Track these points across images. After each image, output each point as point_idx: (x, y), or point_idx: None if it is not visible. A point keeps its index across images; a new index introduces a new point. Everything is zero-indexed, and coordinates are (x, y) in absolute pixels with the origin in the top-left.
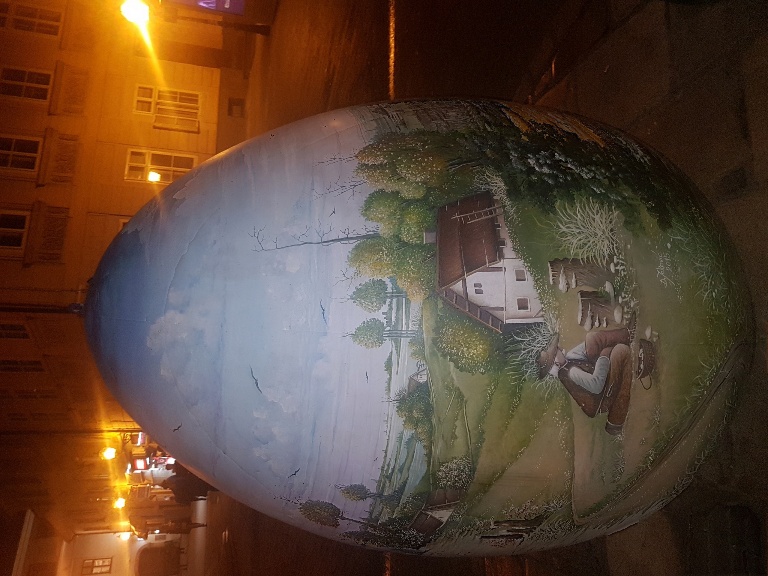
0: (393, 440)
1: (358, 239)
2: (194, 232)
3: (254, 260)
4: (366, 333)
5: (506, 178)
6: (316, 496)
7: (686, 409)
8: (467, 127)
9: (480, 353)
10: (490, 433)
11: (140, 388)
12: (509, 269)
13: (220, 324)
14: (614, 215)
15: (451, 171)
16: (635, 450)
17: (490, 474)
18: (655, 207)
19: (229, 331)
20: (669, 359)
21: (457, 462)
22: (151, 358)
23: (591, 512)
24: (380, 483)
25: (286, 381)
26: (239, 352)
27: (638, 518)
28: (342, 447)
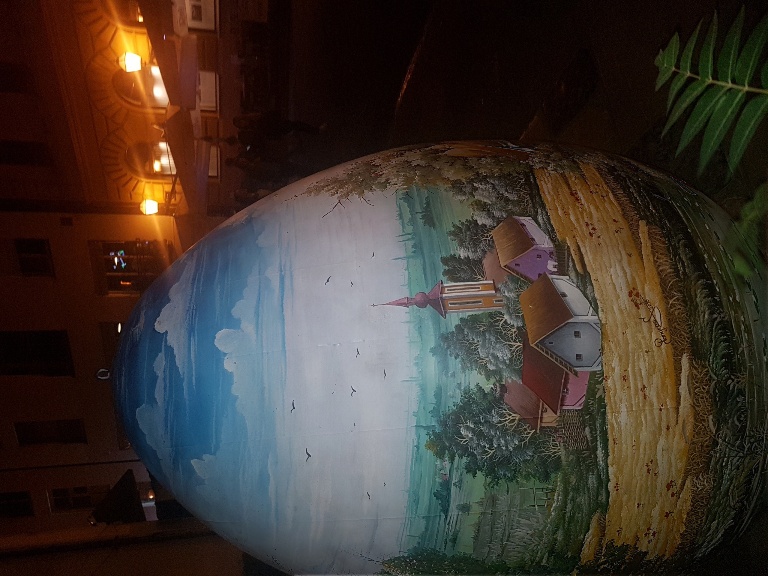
0: None
1: None
2: None
3: None
4: None
5: None
6: None
7: None
8: (521, 559)
9: None
10: None
11: None
12: None
13: None
14: None
15: None
16: None
17: None
18: None
19: None
20: None
21: None
22: None
23: None
24: None
25: None
26: None
27: None
28: None
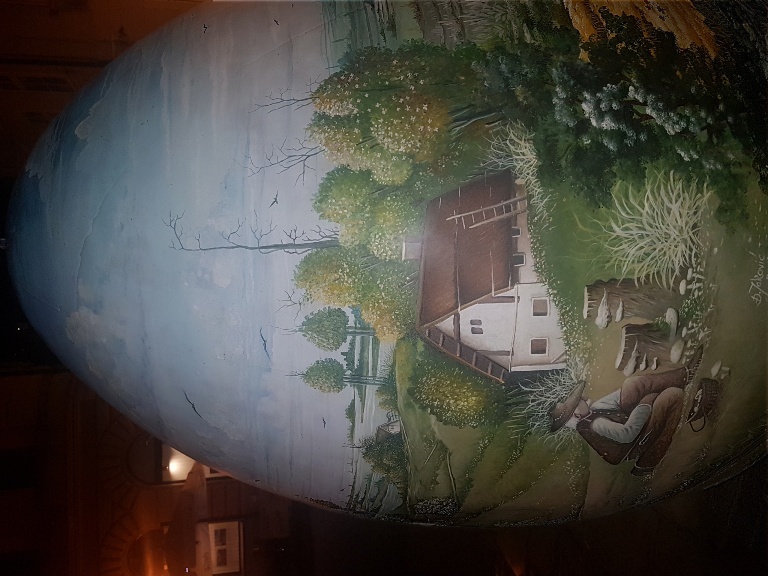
0: (360, 479)
1: (309, 247)
2: (97, 204)
3: (172, 262)
4: (321, 375)
5: (541, 144)
6: (284, 495)
7: (745, 440)
8: (493, 35)
9: (472, 405)
10: (480, 480)
11: None
12: (524, 299)
13: (141, 338)
14: (704, 199)
15: (454, 133)
16: (666, 483)
17: (479, 508)
18: None
19: (153, 348)
20: (737, 395)
21: (439, 500)
22: (76, 351)
23: None
24: (350, 504)
25: (227, 412)
26: (168, 373)
27: None
28: (302, 476)
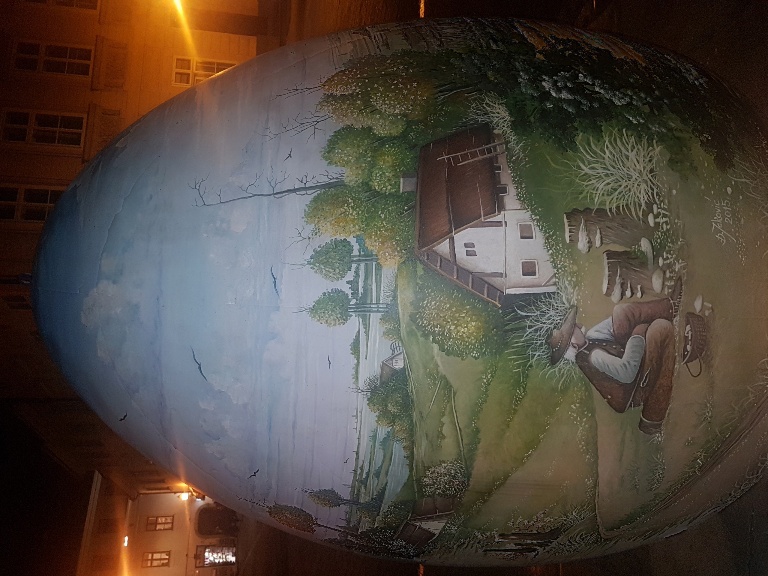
0: (365, 439)
1: (318, 189)
2: (130, 185)
3: (194, 218)
4: (327, 307)
5: (512, 106)
6: (283, 500)
7: (748, 401)
8: (466, 45)
9: (472, 332)
10: (487, 432)
11: (82, 371)
12: (511, 223)
13: (156, 297)
14: (655, 151)
15: (440, 99)
16: (678, 452)
17: (489, 481)
18: (712, 141)
19: (166, 305)
20: (726, 338)
21: (446, 466)
22: (87, 337)
23: (622, 524)
24: (354, 489)
25: (233, 366)
26: (178, 331)
27: (684, 527)
28: (305, 446)
